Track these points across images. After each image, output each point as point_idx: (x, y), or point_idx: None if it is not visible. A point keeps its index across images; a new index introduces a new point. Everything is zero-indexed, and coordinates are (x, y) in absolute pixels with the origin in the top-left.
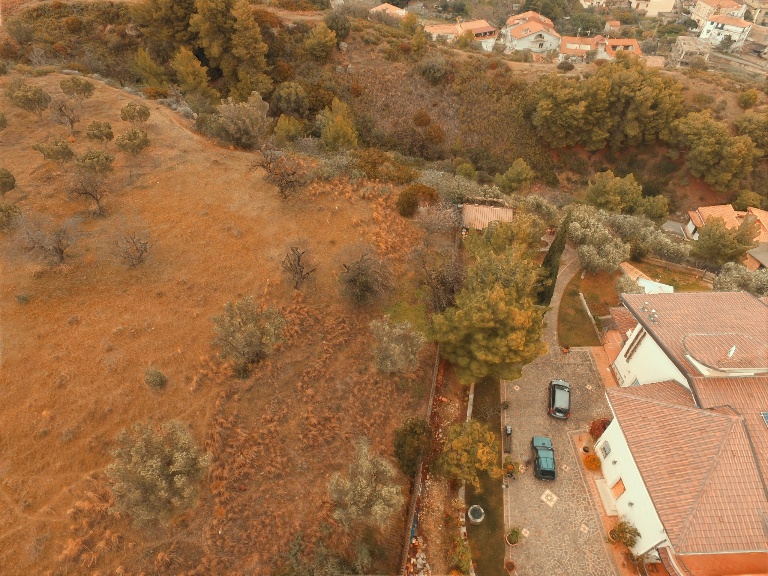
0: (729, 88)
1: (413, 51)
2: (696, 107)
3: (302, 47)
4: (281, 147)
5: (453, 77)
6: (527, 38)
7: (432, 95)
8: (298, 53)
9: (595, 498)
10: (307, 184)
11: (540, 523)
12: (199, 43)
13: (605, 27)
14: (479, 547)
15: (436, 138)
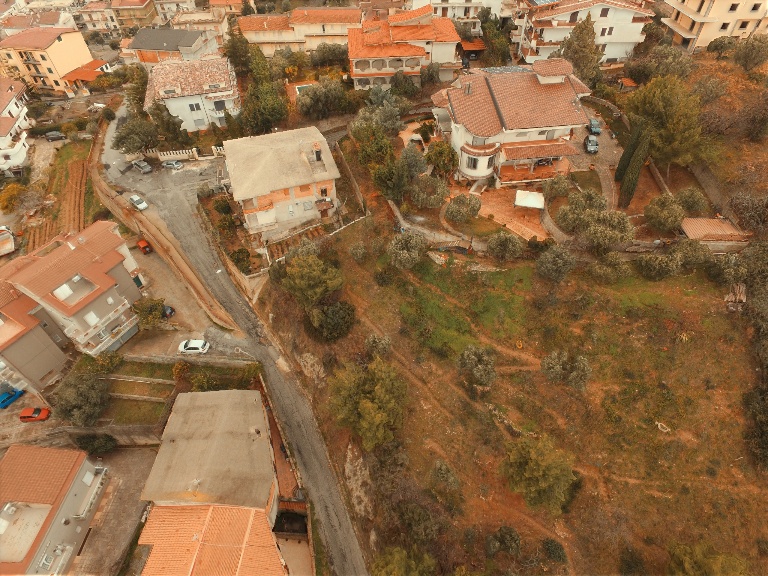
0: None
1: None
2: None
3: None
4: None
5: None
6: None
7: None
8: None
9: None
10: None
11: None
12: None
13: None
14: None
15: None
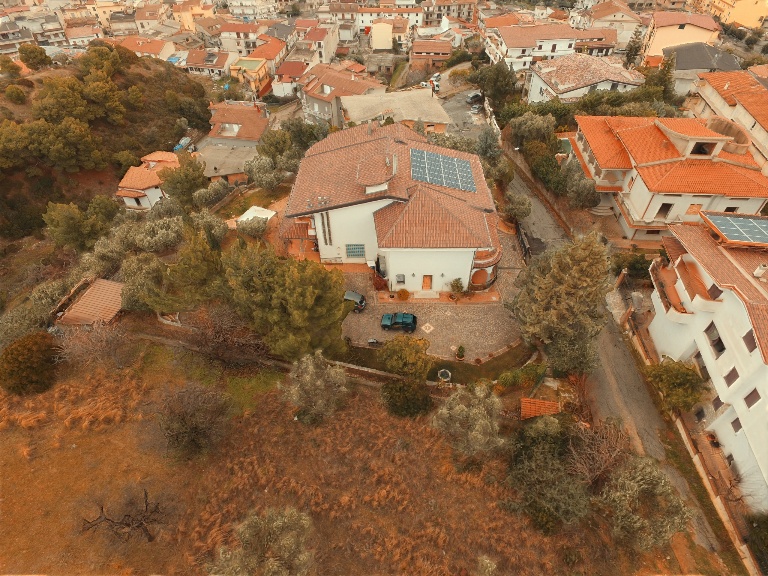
0: None
1: None
2: None
3: None
4: None
5: None
6: None
7: None
8: None
9: (427, 302)
10: None
11: (446, 338)
12: None
13: None
14: (467, 380)
15: None
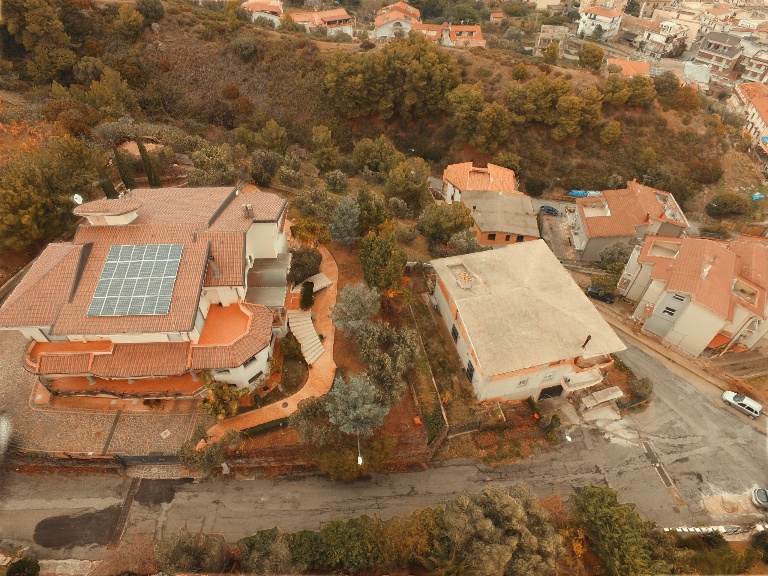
0: (506, 63)
1: (228, 32)
2: (475, 80)
3: (112, 27)
4: None
5: (263, 55)
6: (386, 26)
7: (243, 71)
8: (108, 32)
9: None
10: None
11: (8, 347)
12: None
13: (490, 18)
14: None
15: (242, 109)
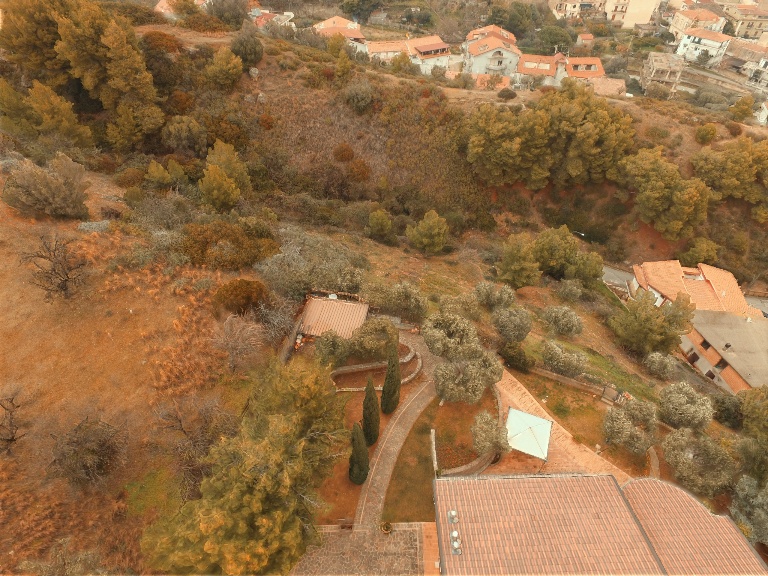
0: (686, 121)
1: (337, 77)
2: (649, 142)
3: (204, 74)
4: (134, 204)
5: (381, 106)
6: (484, 55)
7: (357, 126)
8: (199, 81)
9: None
10: (108, 274)
11: None
12: (71, 73)
13: (577, 40)
14: None
15: (359, 175)
